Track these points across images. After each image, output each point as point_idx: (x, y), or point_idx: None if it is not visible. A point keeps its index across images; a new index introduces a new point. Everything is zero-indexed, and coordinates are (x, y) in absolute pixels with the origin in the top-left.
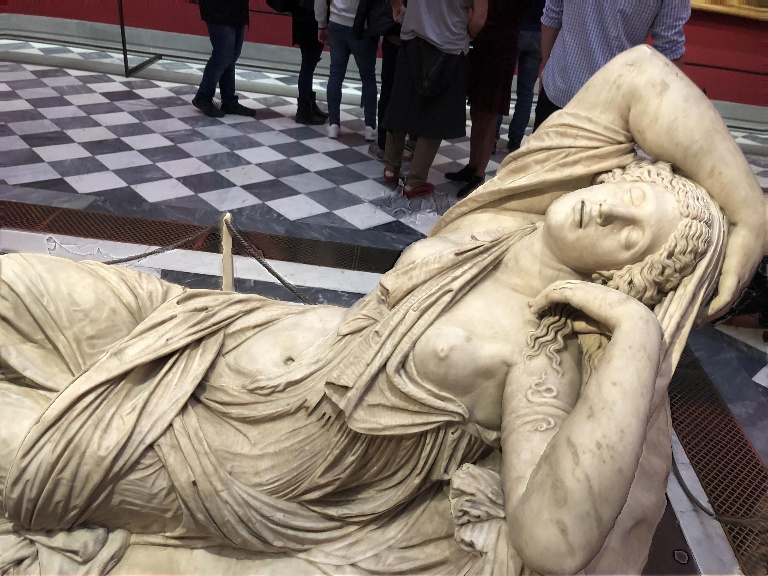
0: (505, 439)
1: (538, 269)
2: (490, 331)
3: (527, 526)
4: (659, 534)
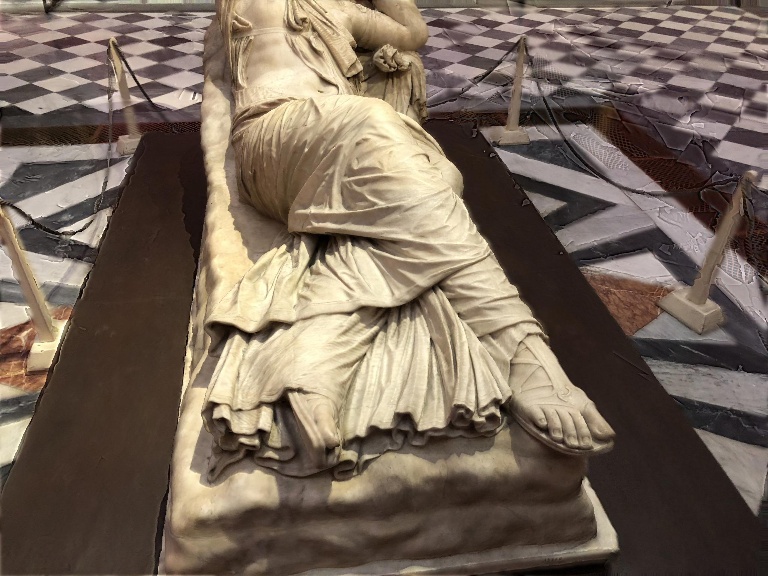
0: None
1: None
2: (330, 5)
3: None
4: None
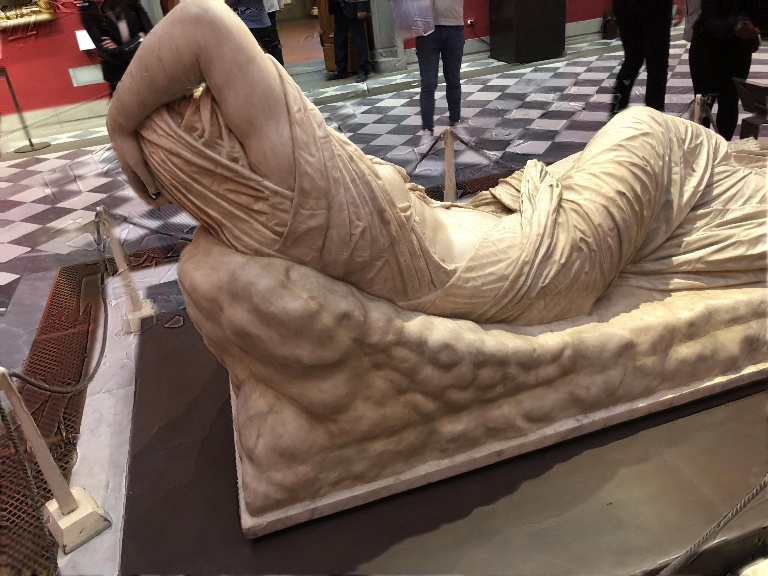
0: None
1: None
2: None
3: None
4: (153, 492)
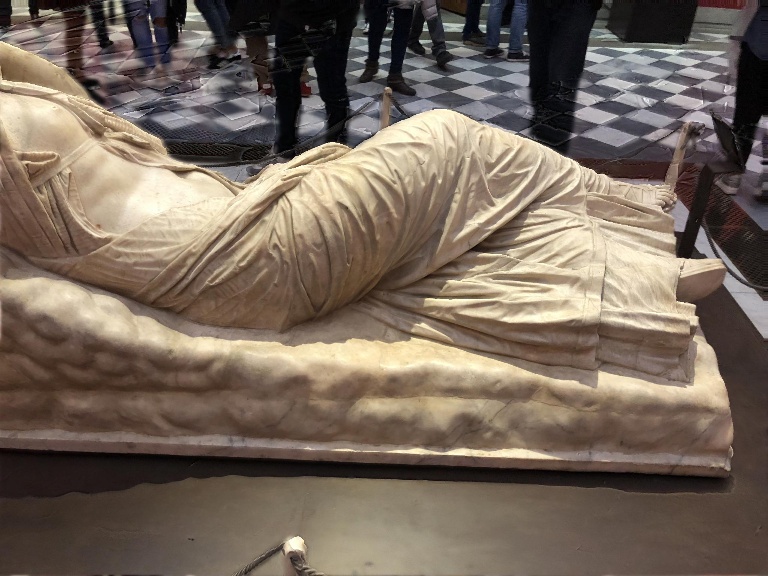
0: None
1: None
2: None
3: None
4: None
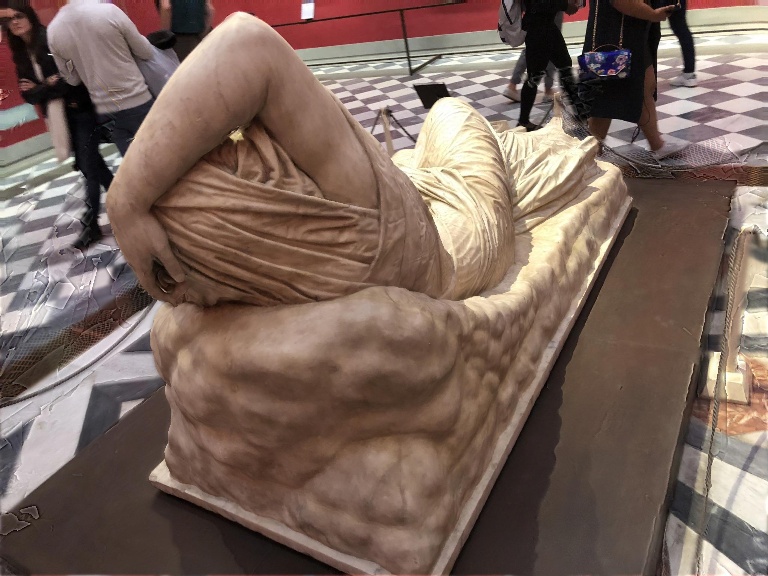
0: None
1: None
2: None
3: None
4: None
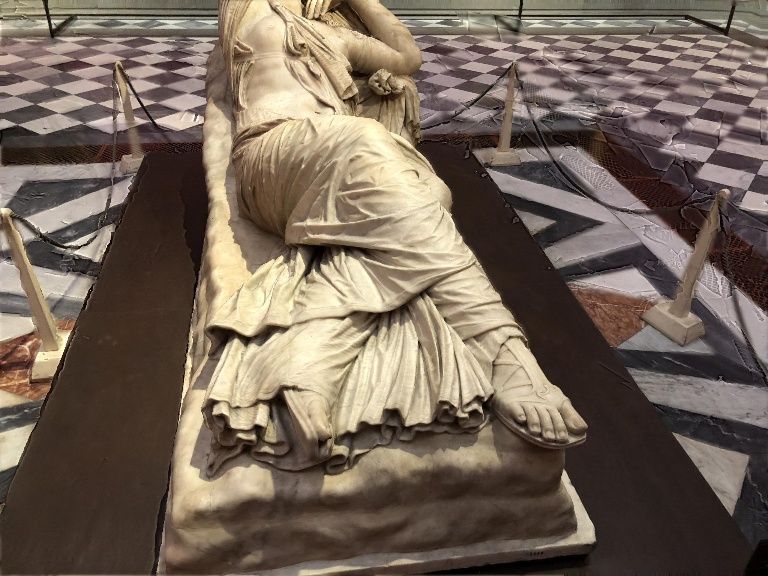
0: (371, 56)
1: (298, 3)
2: None
3: (413, 55)
4: None
